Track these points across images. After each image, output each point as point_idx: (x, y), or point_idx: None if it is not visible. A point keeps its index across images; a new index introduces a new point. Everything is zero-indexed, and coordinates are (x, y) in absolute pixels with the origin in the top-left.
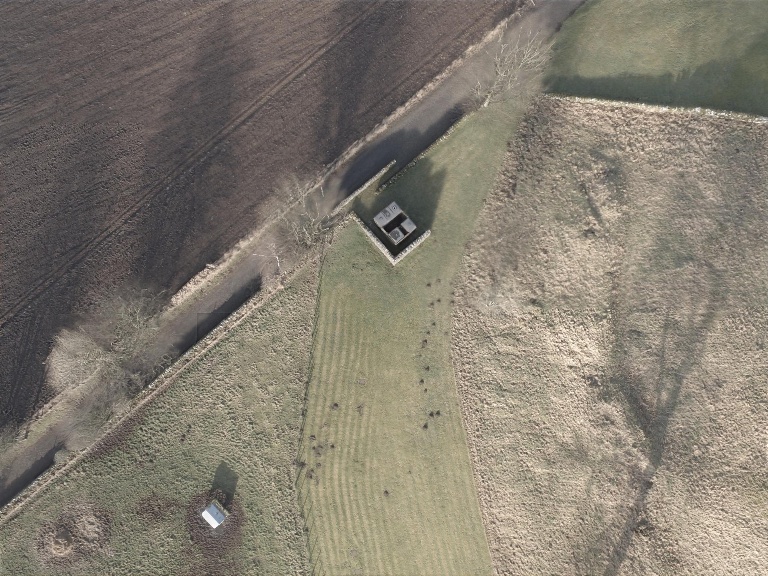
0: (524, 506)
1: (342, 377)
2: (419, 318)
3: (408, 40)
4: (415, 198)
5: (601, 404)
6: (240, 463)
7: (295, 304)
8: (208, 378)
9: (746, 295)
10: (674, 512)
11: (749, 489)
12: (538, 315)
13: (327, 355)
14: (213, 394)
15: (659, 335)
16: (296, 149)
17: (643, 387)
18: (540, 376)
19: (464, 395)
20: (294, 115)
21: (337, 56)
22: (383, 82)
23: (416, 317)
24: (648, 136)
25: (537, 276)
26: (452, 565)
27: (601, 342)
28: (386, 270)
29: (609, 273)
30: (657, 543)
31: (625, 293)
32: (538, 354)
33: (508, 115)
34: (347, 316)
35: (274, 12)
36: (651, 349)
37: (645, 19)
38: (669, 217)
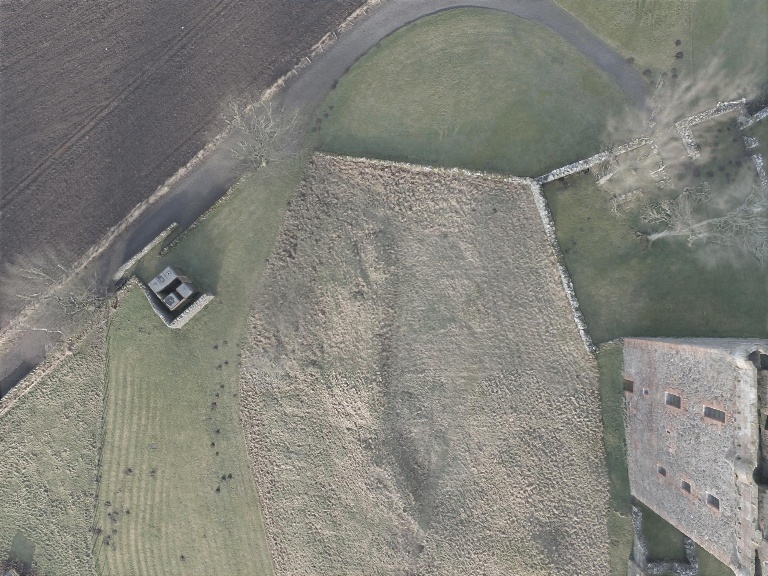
0: (314, 568)
1: (134, 442)
2: (207, 381)
3: (188, 100)
4: (199, 260)
5: (374, 468)
6: (36, 532)
7: (85, 370)
8: (1, 446)
9: (501, 358)
10: (444, 575)
11: (506, 554)
12: (318, 377)
13: (119, 420)
14: (7, 462)
15: (428, 397)
16: (80, 213)
17: (415, 449)
18: (323, 438)
19: (254, 457)
20: (77, 178)
21: (119, 117)
22: (165, 143)
23: (204, 380)
24: (415, 195)
25: (317, 337)
26: None
27: (372, 405)
28: (173, 333)
29: (378, 335)
30: None
31: (397, 354)
32: (320, 416)
33: (287, 174)
34: (137, 380)
35: (55, 74)
36: (421, 411)
37: (414, 76)
38: (435, 277)
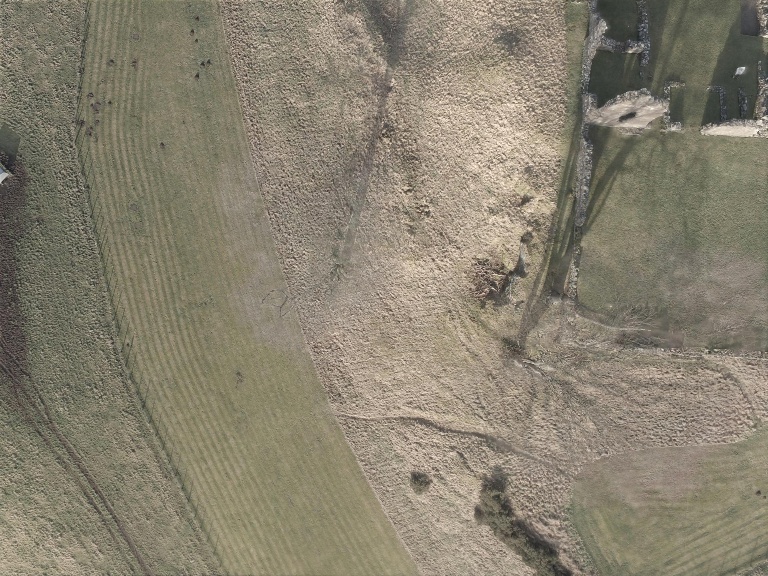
0: (289, 142)
1: (116, 33)
2: None
3: None
4: None
5: (345, 18)
6: (21, 124)
7: None
8: None
9: None
10: (412, 111)
11: (469, 66)
12: None
13: (102, 12)
14: None
15: None
16: None
17: None
18: (298, 10)
19: (232, 42)
20: None
21: None
22: None
23: None
24: None
25: None
26: (226, 211)
27: None
28: None
29: None
30: (397, 144)
31: None
32: None
33: None
34: None
35: None
36: None
37: None
38: None
